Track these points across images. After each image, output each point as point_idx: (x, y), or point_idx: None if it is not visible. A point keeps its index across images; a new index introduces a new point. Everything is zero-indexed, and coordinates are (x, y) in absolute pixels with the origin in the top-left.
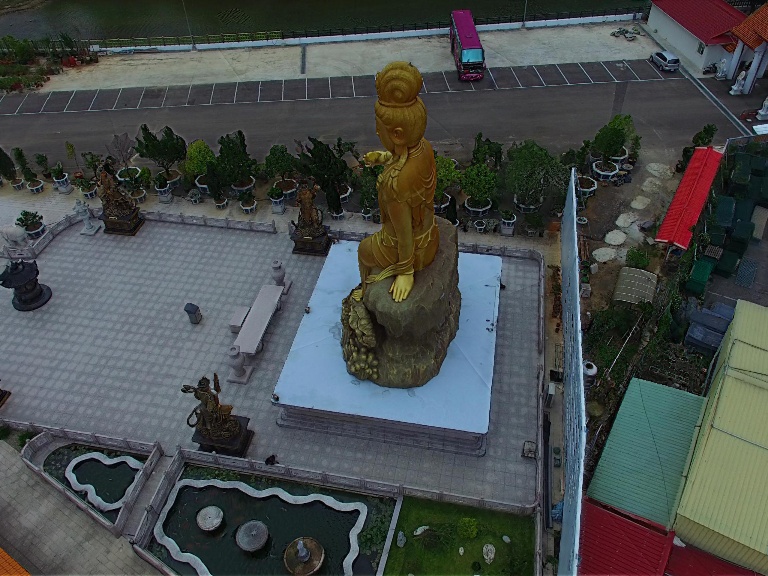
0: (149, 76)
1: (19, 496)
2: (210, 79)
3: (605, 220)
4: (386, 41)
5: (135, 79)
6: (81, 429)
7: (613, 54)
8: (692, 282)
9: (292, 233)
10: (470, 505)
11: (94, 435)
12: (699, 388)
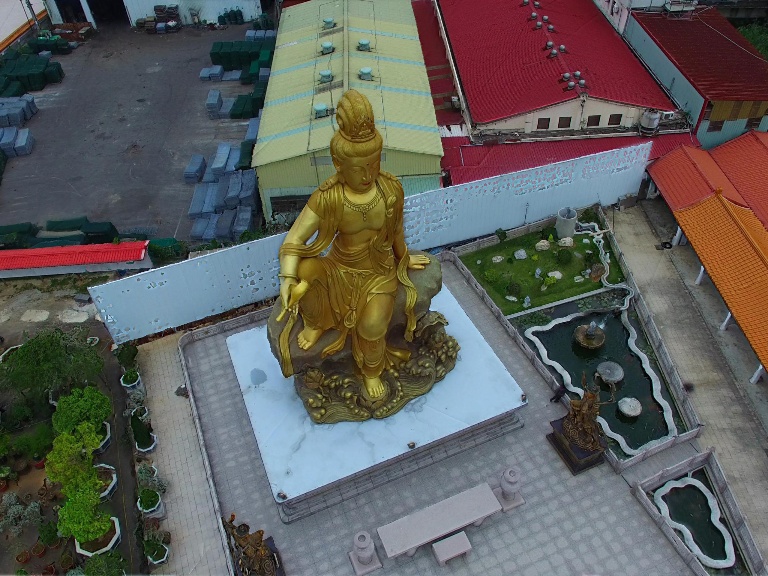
0: None
1: None
2: None
3: None
4: None
5: None
6: None
7: None
8: (175, 246)
9: None
10: None
11: None
12: (290, 226)
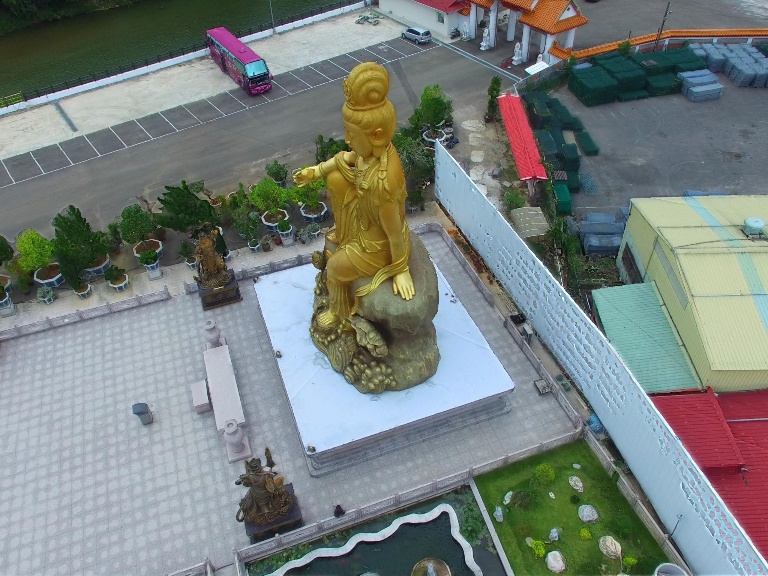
0: None
1: None
2: None
3: None
4: (146, 77)
5: None
6: None
7: (369, 39)
8: (562, 204)
9: (189, 292)
10: (530, 455)
11: None
12: None
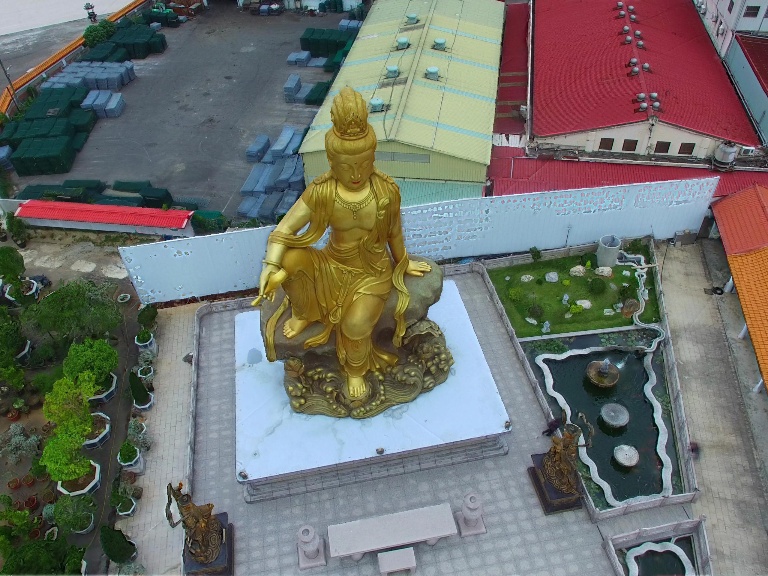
0: None
1: None
2: None
3: None
4: None
5: None
6: None
7: None
8: (219, 220)
9: None
10: None
11: None
12: None
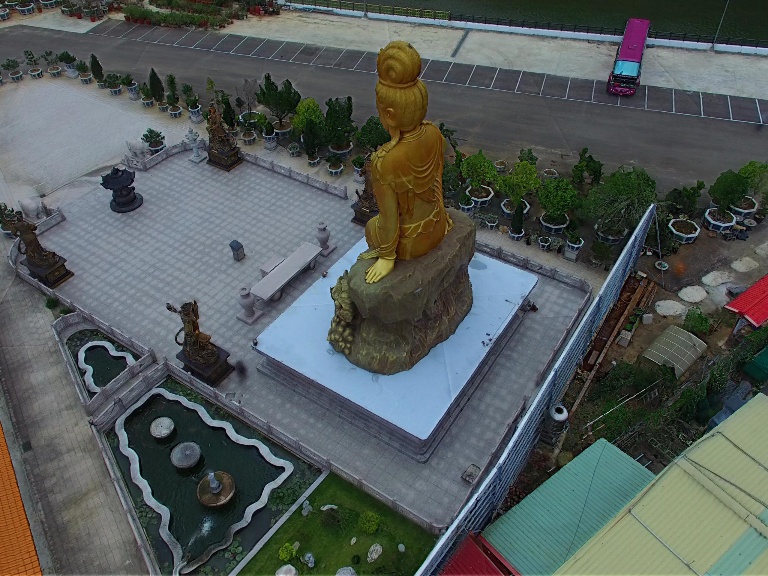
0: (314, 34)
1: (39, 357)
2: (365, 47)
3: (690, 272)
4: (552, 39)
5: (301, 35)
6: (108, 320)
7: None
8: (752, 365)
9: None
10: (386, 503)
11: (110, 327)
12: None
